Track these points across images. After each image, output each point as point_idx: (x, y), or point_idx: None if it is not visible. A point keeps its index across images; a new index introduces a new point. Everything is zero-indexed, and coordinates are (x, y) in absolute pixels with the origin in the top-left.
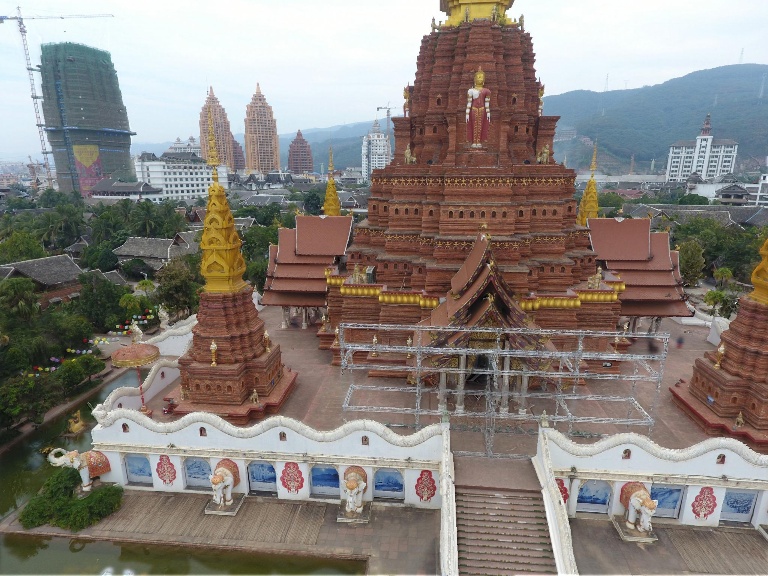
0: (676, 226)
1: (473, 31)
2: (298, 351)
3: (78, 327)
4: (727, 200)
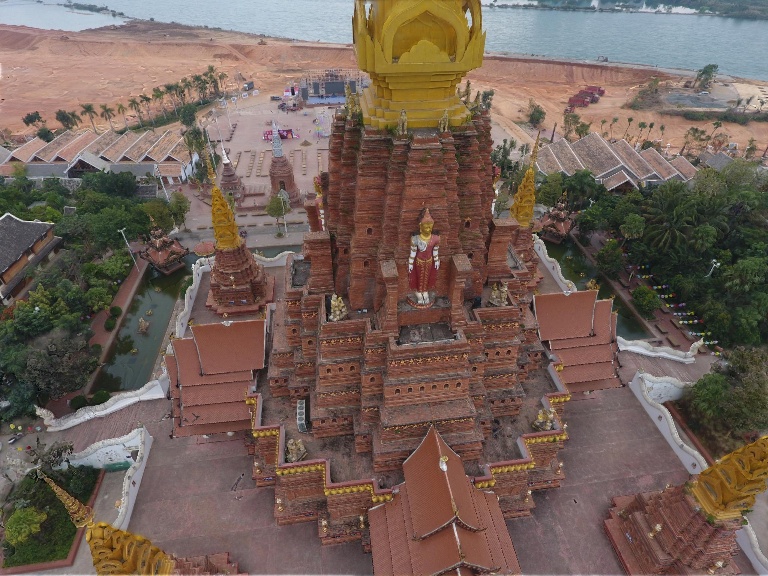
0: None
1: None
2: None
3: (709, 311)
4: None
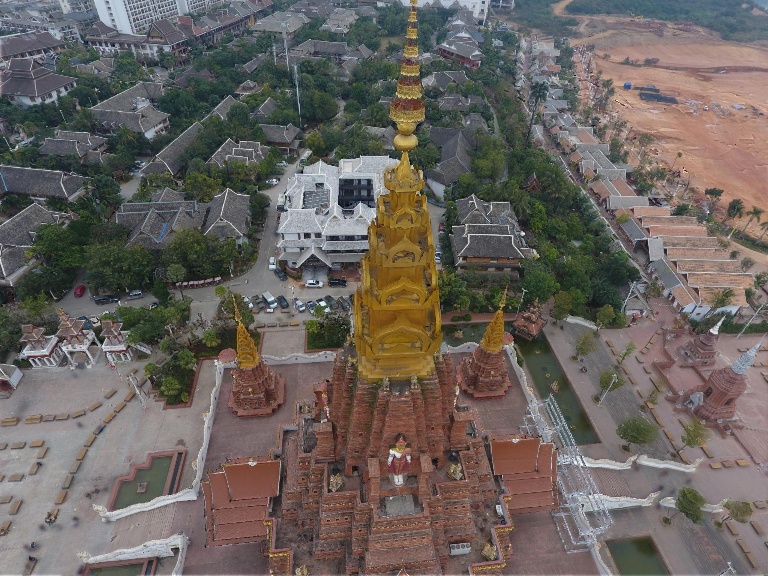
0: (41, 253)
1: None
2: None
3: None
4: None
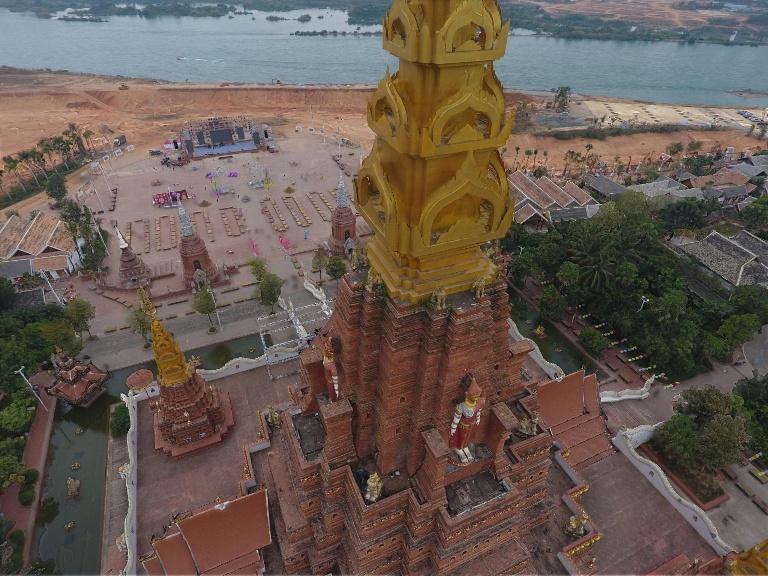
0: None
1: None
2: None
3: (651, 346)
4: None
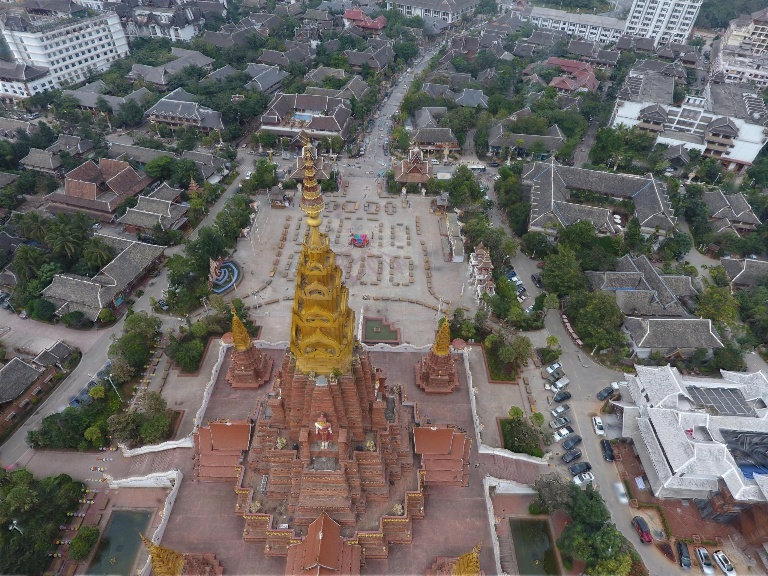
0: (558, 231)
1: (316, 393)
2: (224, 519)
3: (68, 497)
4: (646, 125)
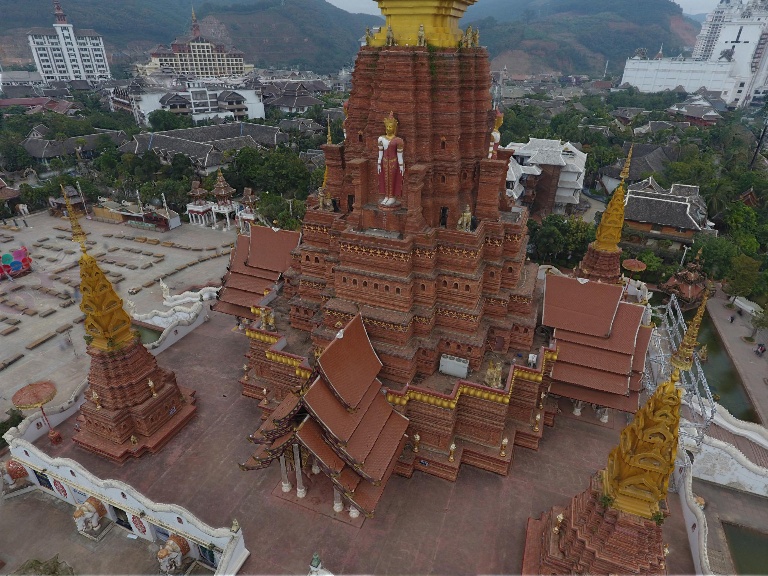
0: (236, 159)
1: None
2: (456, 505)
3: None
4: (176, 110)
